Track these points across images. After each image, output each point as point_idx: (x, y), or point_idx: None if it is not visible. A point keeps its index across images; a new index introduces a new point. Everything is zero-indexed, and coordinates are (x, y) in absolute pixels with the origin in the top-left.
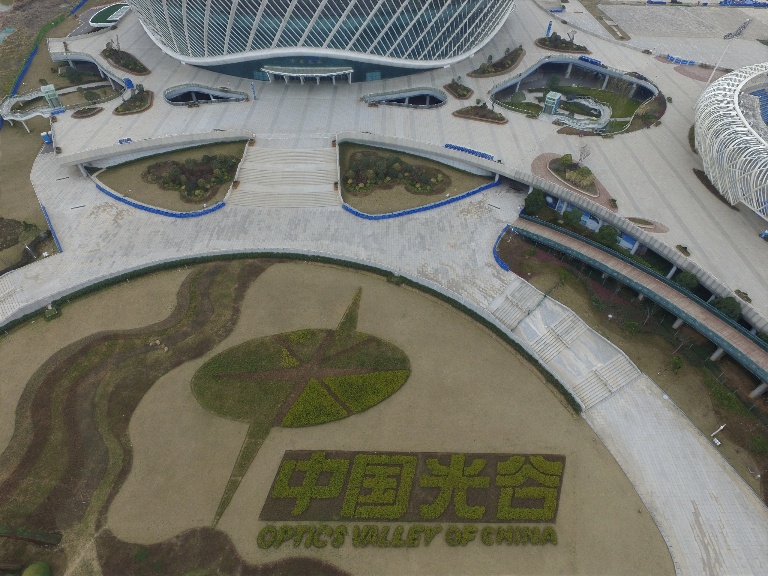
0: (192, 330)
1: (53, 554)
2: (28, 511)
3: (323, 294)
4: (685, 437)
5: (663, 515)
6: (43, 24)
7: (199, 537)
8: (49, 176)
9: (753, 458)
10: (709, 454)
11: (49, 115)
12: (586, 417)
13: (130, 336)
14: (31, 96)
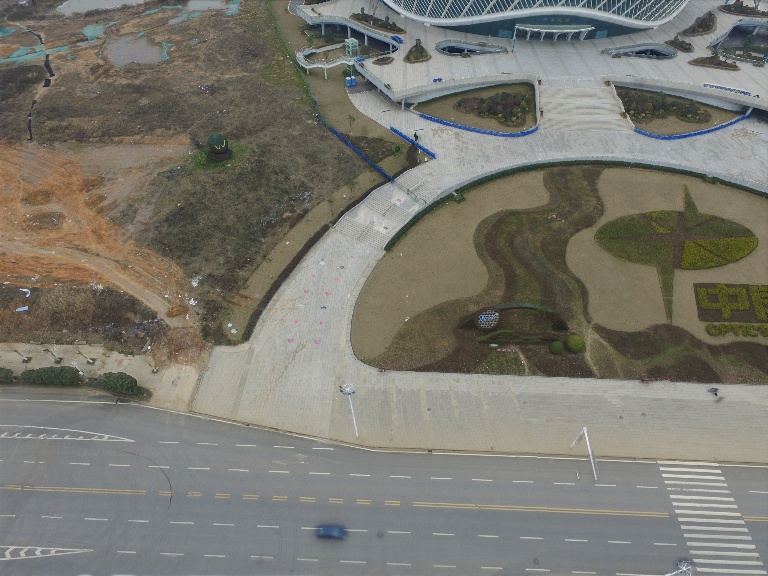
0: (573, 210)
1: (569, 335)
2: (533, 312)
3: (658, 189)
4: None
5: None
6: None
7: (664, 329)
8: (373, 109)
9: None
10: None
11: None
12: None
13: (529, 213)
14: (308, 51)
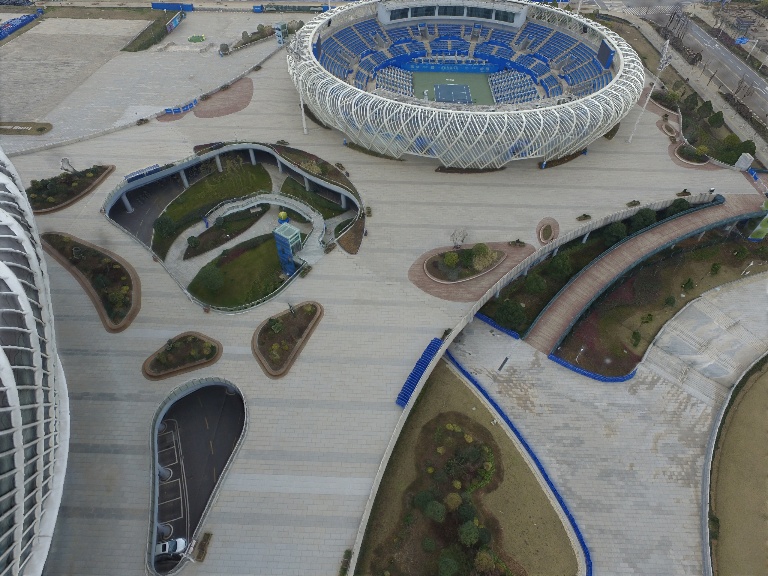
0: None
1: None
2: None
3: None
4: (751, 290)
5: None
6: None
7: None
8: None
9: (751, 259)
10: (758, 281)
11: None
12: None
13: None
14: None
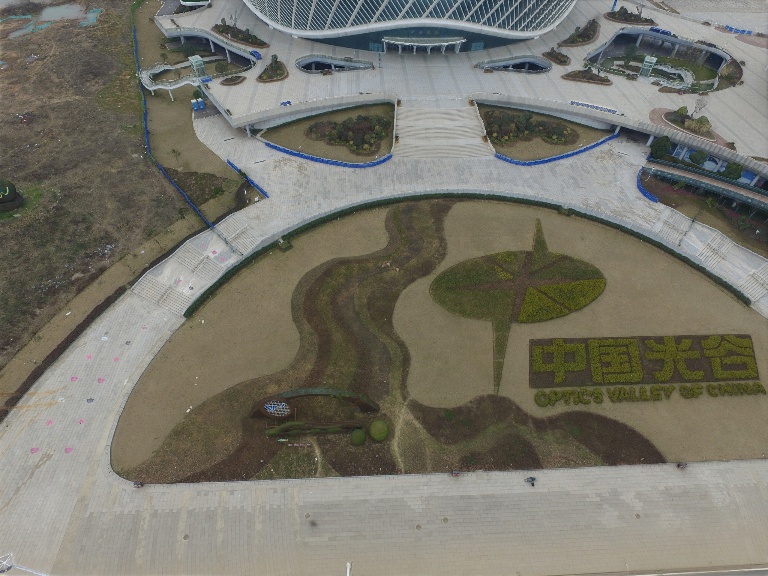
0: (412, 255)
1: (378, 418)
2: None
3: (509, 224)
4: None
5: None
6: (126, 4)
7: (488, 401)
8: (216, 137)
9: None
10: None
11: (200, 83)
12: (755, 308)
13: (362, 261)
14: (159, 69)
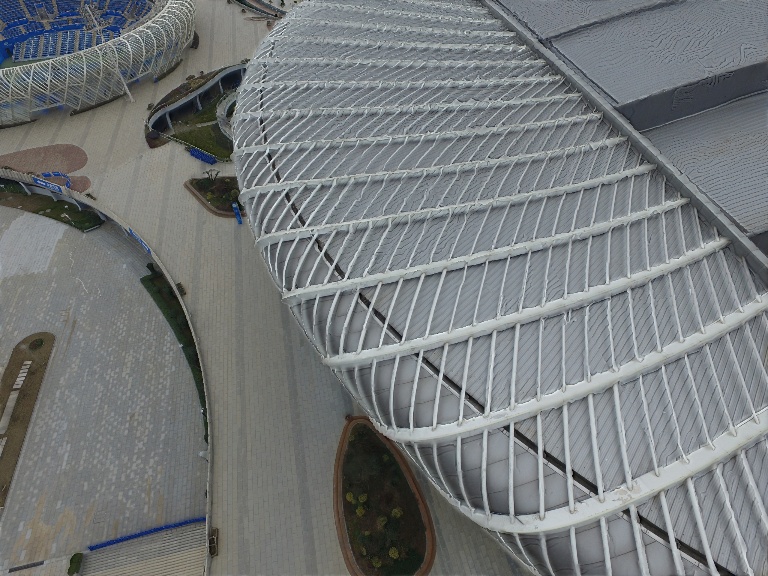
0: None
1: None
2: None
3: None
4: None
5: None
6: None
7: None
8: None
9: None
10: None
11: None
12: None
13: None
14: None
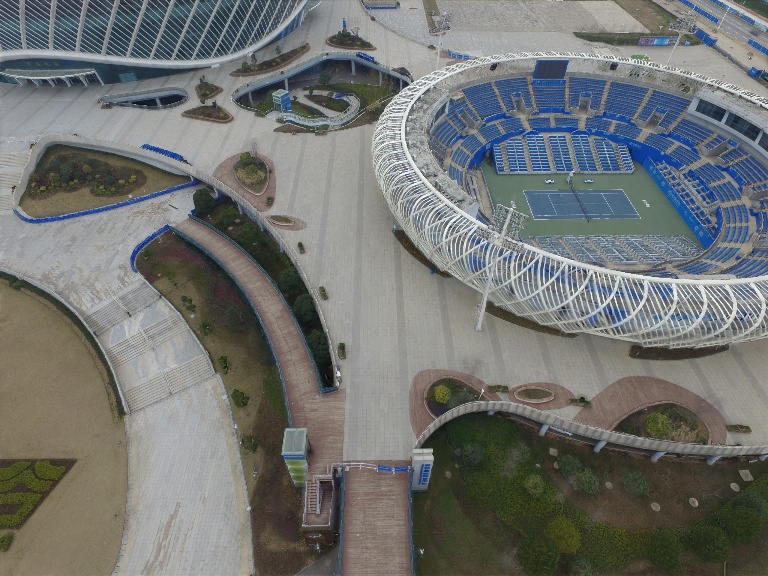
0: None
1: None
2: None
3: None
4: (216, 437)
5: (138, 518)
6: None
7: None
8: None
9: (264, 457)
10: (229, 454)
11: None
12: (128, 419)
13: None
14: None
